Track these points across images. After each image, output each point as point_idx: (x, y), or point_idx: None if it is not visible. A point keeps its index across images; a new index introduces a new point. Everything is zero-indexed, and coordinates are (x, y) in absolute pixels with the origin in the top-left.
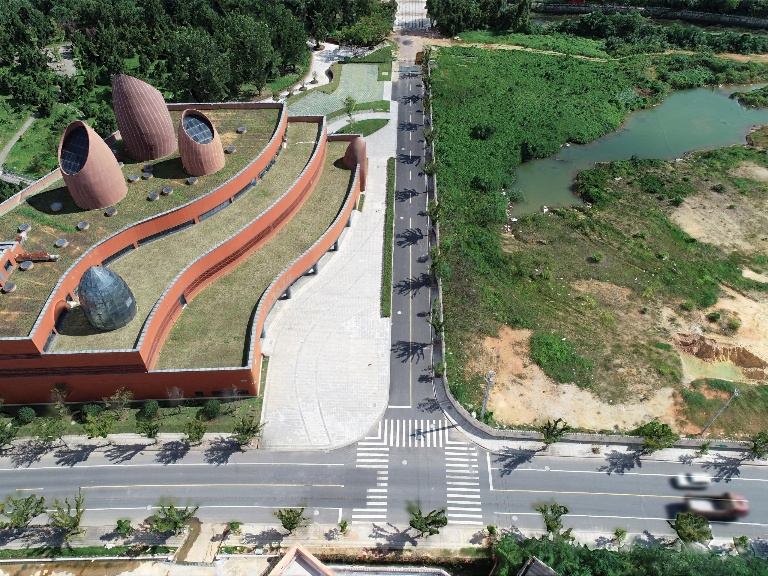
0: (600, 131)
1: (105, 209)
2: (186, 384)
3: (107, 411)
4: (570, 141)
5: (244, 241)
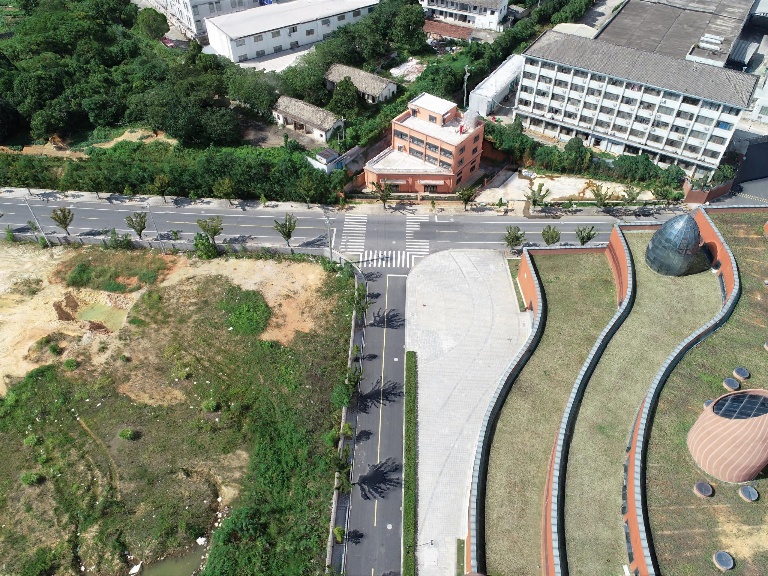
0: None
1: None
2: None
3: None
4: None
5: None
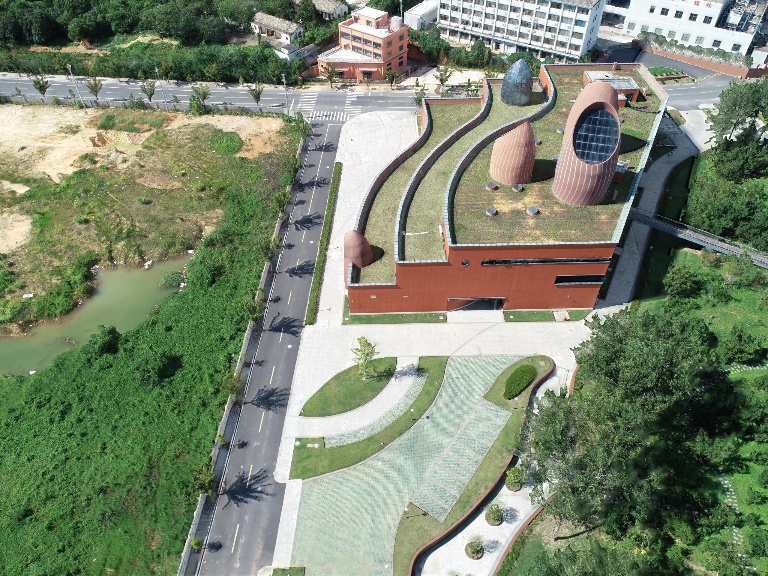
0: None
1: None
2: None
3: None
4: None
5: None
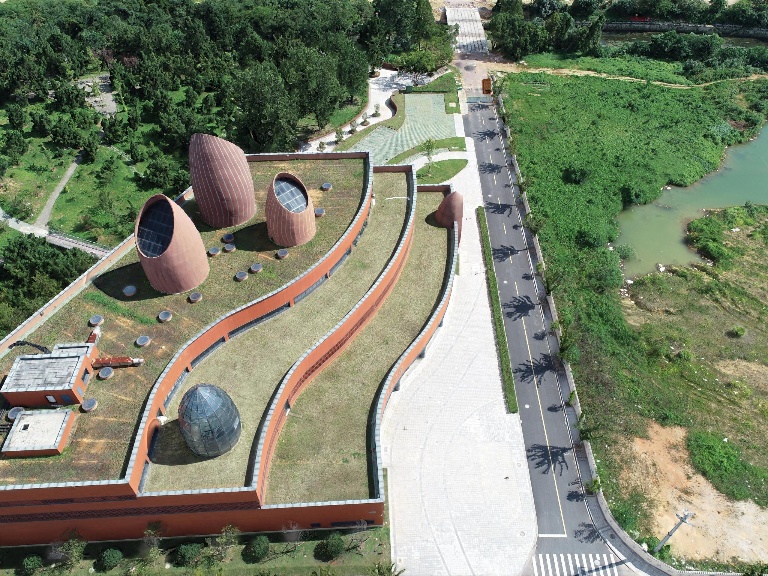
0: (701, 171)
1: (187, 293)
2: (303, 517)
3: (206, 548)
4: (670, 183)
5: (349, 327)
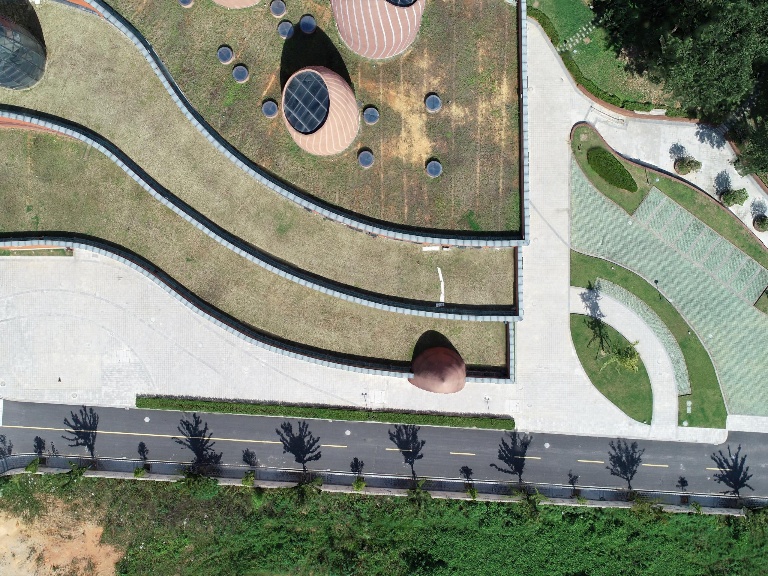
0: None
1: None
2: None
3: None
4: None
5: None
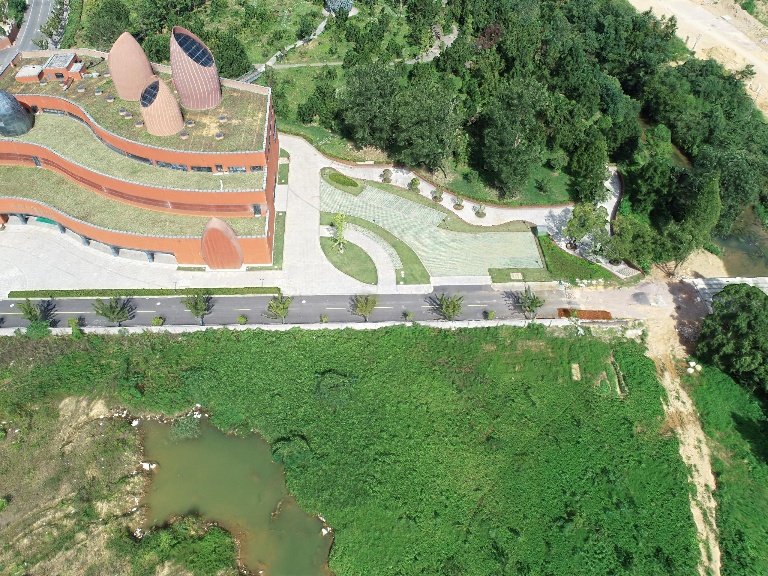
0: None
1: (118, 97)
2: None
3: None
4: None
5: (79, 173)
